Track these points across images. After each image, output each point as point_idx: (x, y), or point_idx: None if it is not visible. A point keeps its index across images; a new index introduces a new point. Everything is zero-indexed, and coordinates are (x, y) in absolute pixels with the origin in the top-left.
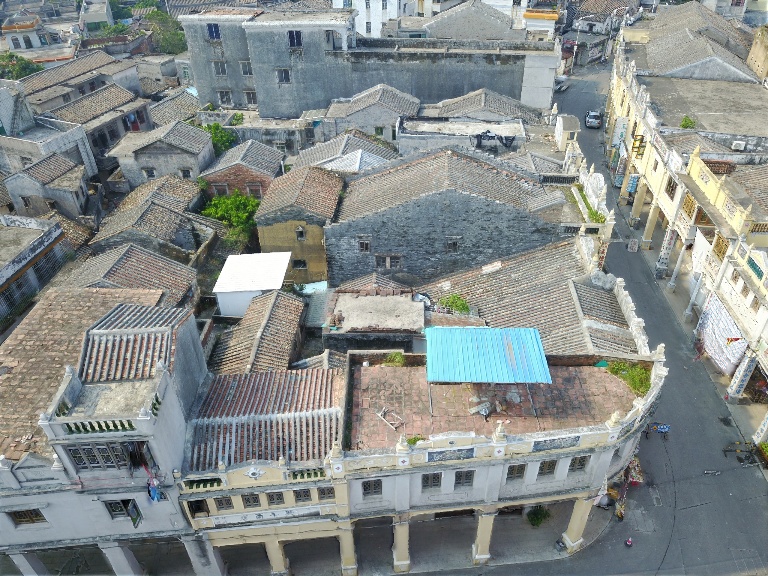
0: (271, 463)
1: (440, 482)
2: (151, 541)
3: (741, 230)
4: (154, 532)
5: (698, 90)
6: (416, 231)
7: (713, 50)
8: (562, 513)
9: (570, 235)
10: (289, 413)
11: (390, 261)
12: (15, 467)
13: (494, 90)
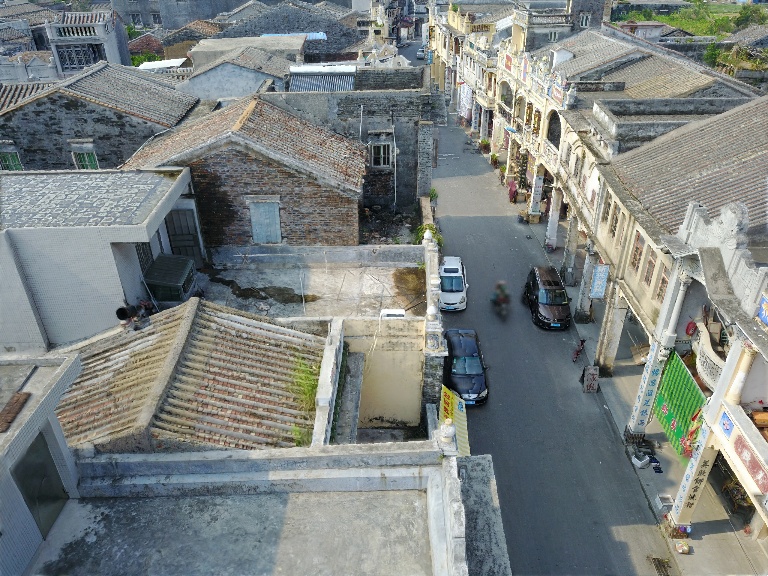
0: None
1: None
2: None
3: (466, 30)
4: None
5: (476, 7)
6: None
7: None
8: None
9: (365, 37)
10: None
11: None
12: (27, 65)
13: (333, 2)
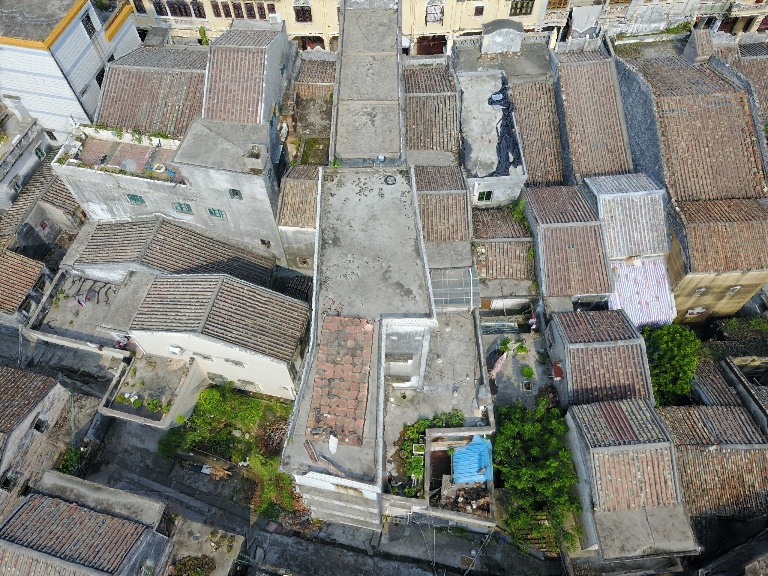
0: None
1: None
2: None
3: None
4: None
5: None
6: None
7: None
8: None
9: None
10: None
11: None
12: None
13: None
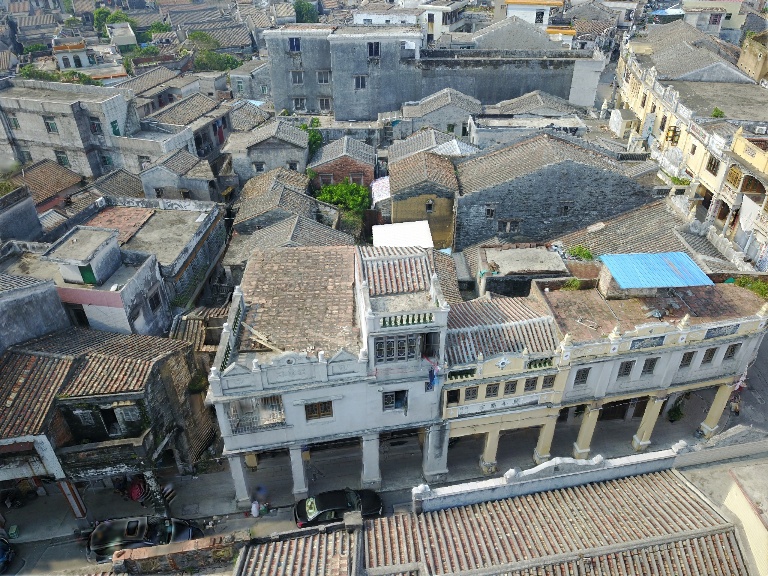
0: (517, 354)
1: (630, 371)
2: (407, 432)
3: None
4: (411, 423)
5: (710, 90)
6: (536, 198)
7: (716, 57)
8: (691, 413)
9: (661, 196)
10: (510, 322)
11: (510, 226)
12: (330, 361)
13: (546, 91)
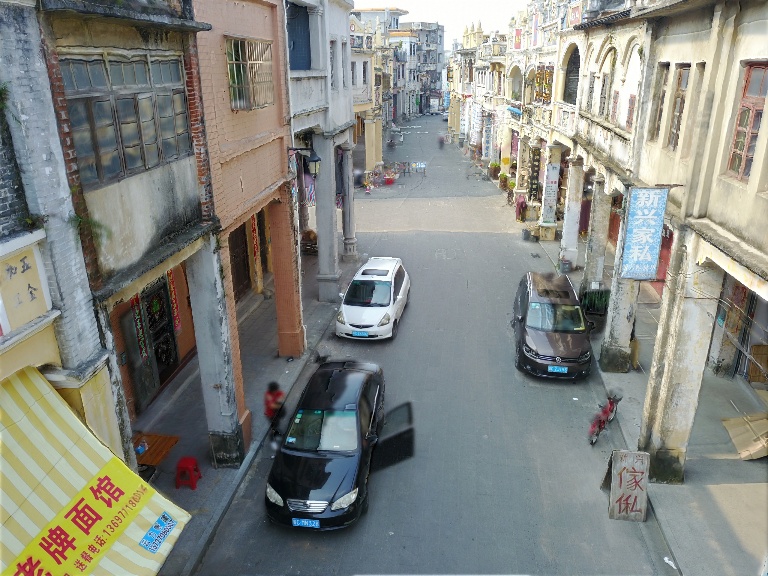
0: None
1: None
2: None
3: (477, 42)
4: None
5: None
6: None
7: None
8: None
9: None
10: None
11: None
12: None
13: None
